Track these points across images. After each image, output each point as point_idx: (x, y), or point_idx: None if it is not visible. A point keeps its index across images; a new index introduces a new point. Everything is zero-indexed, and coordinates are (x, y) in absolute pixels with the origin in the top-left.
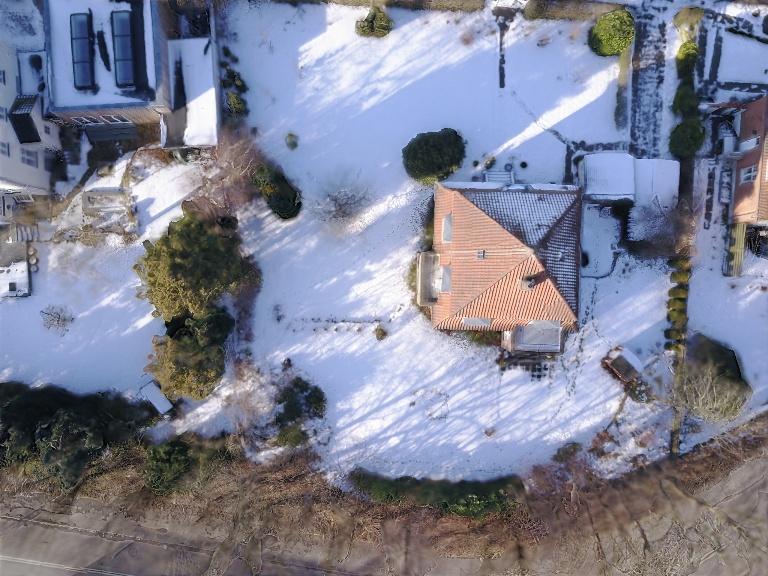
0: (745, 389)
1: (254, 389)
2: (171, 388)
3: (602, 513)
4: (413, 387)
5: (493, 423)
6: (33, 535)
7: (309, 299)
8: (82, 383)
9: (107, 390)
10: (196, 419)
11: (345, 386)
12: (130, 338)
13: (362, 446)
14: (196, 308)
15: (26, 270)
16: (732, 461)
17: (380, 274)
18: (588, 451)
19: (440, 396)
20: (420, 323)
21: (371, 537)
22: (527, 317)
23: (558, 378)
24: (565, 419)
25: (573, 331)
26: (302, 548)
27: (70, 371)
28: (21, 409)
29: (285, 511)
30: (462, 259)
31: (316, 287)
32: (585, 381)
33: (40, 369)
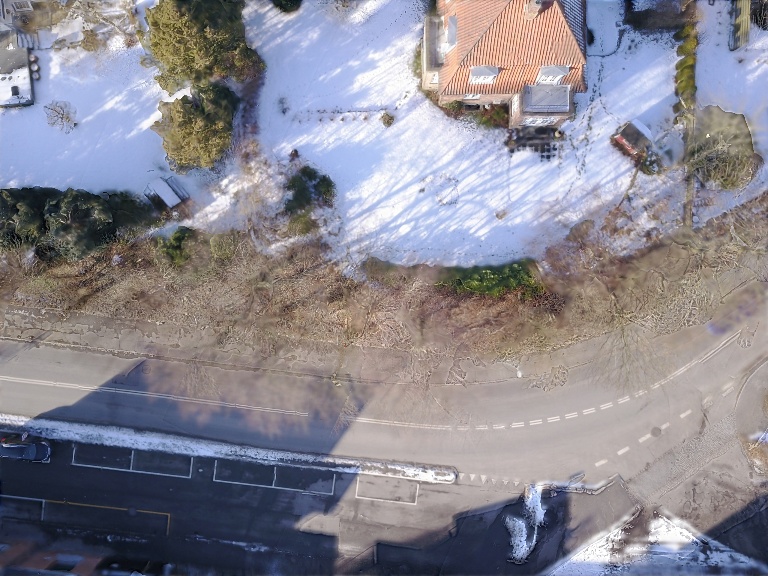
0: (756, 159)
1: (262, 180)
2: (179, 149)
3: (617, 280)
4: (422, 173)
5: (504, 206)
6: (45, 356)
7: (314, 91)
8: (89, 189)
9: (114, 193)
10: (205, 219)
11: (353, 175)
12: (135, 140)
13: (373, 236)
14: (201, 54)
15: (28, 76)
16: (746, 238)
17: (384, 62)
18: (601, 229)
19: (449, 181)
20: (426, 109)
21: (385, 336)
22: (535, 61)
23: (568, 158)
24: (576, 198)
25: (581, 89)
26: (316, 357)
27: (76, 177)
28: (29, 193)
29: (298, 317)
30: (467, 1)
31: (320, 79)
32: (595, 159)
33: (46, 178)
